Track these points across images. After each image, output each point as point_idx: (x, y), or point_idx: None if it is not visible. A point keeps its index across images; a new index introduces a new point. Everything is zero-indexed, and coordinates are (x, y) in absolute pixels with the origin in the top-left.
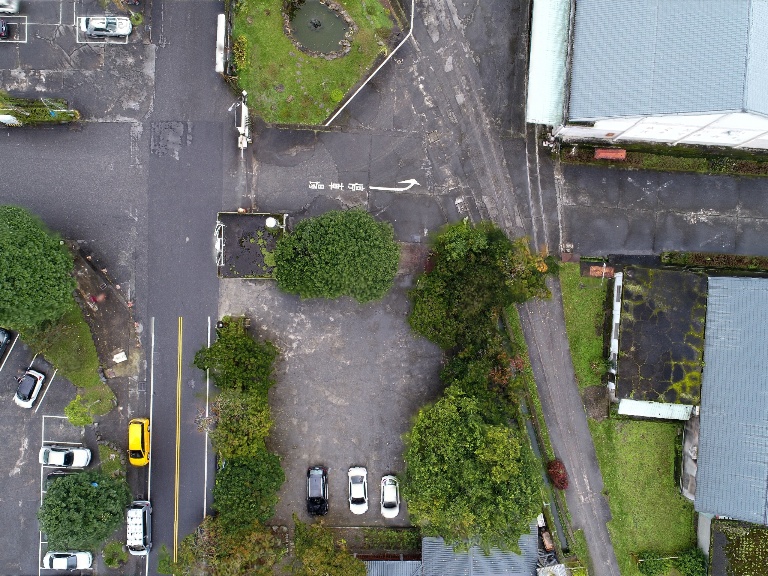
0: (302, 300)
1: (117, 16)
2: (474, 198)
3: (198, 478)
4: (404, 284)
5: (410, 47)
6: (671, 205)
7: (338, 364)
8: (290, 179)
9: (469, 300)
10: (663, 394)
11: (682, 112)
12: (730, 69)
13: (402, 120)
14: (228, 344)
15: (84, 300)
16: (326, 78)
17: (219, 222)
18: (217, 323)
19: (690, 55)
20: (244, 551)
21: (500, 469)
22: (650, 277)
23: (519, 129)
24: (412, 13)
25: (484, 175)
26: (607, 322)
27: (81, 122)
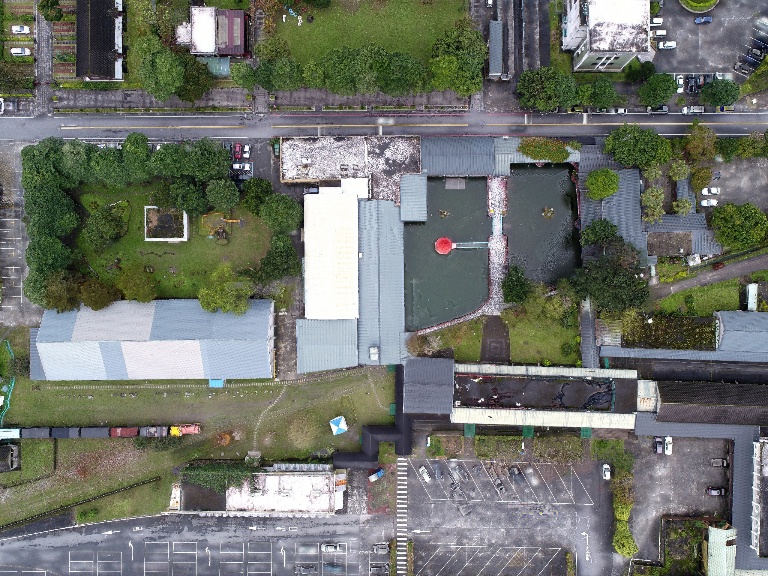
0: None
1: None
2: None
3: None
4: None
5: None
6: None
7: (756, 183)
8: None
9: None
10: (762, 298)
11: None
12: None
13: None
14: None
15: None
16: None
17: None
18: None
19: None
20: None
21: None
22: None
23: None
24: None
25: None
26: None
27: None
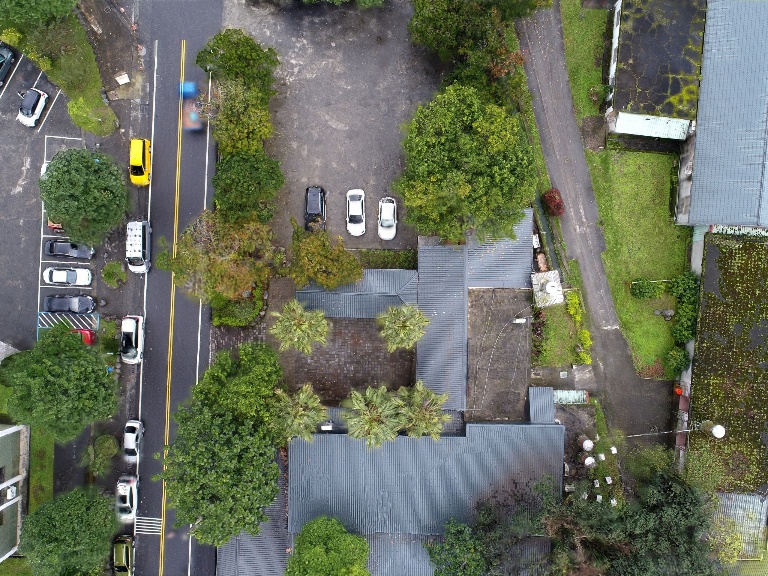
0: (304, 25)
1: None
2: None
3: (198, 200)
4: (406, 11)
5: None
6: None
7: (339, 89)
8: None
9: None
10: (660, 106)
11: None
12: None
13: None
14: (230, 39)
15: (88, 23)
16: None
17: None
18: None
19: None
20: (242, 235)
21: (497, 139)
22: None
23: None
24: None
25: None
26: (606, 53)
27: None
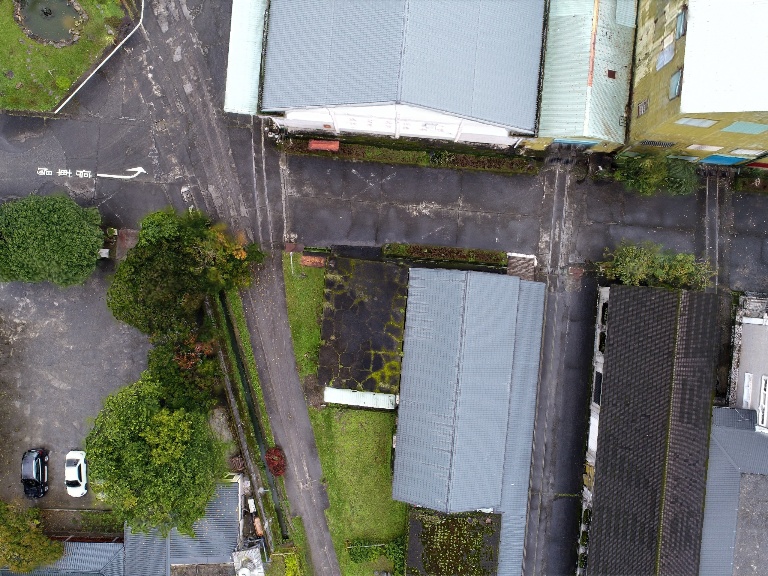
0: (27, 285)
1: None
2: (200, 187)
3: None
4: None
5: (140, 37)
6: (394, 197)
7: (61, 348)
8: (19, 165)
9: (151, 285)
10: (362, 383)
11: (349, 103)
12: (388, 61)
13: (130, 109)
14: None
15: None
16: (55, 66)
17: None
18: None
19: (358, 47)
20: None
21: (161, 452)
22: (352, 267)
23: (245, 119)
24: (142, 3)
25: (210, 164)
26: None
27: None
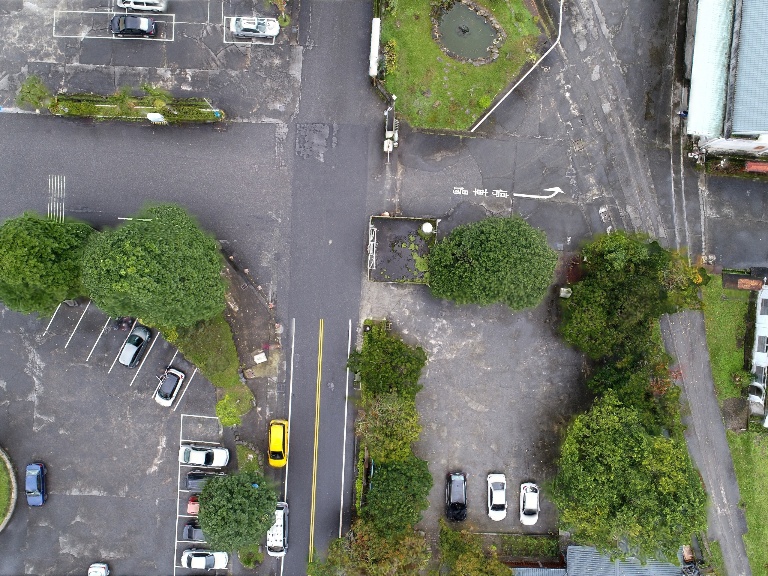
0: (444, 305)
1: (264, 17)
2: (618, 207)
3: (335, 480)
4: None
5: (557, 55)
6: None
7: (479, 370)
8: (434, 184)
9: (632, 310)
10: None
11: None
12: None
13: (548, 128)
14: (384, 348)
15: (225, 300)
16: (473, 84)
17: (372, 226)
18: (364, 326)
19: None
20: (400, 556)
21: (668, 480)
22: None
23: (665, 140)
24: (560, 21)
25: (628, 185)
26: (748, 335)
27: (226, 122)
